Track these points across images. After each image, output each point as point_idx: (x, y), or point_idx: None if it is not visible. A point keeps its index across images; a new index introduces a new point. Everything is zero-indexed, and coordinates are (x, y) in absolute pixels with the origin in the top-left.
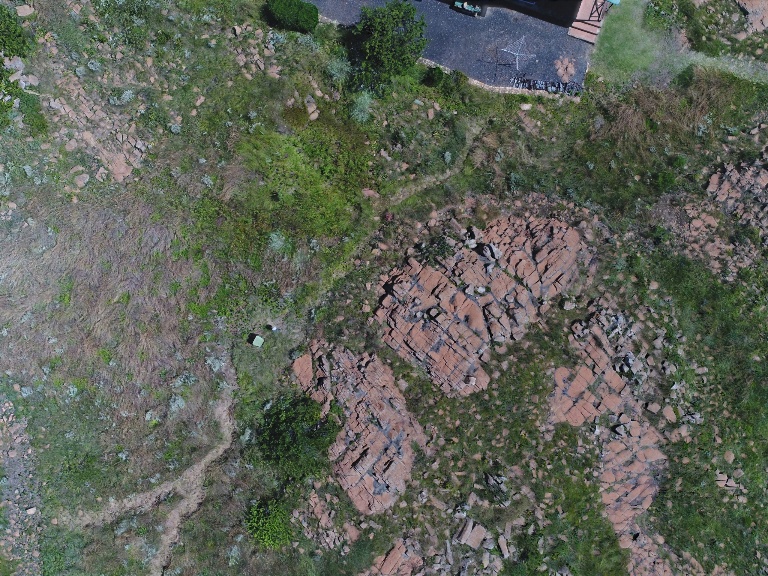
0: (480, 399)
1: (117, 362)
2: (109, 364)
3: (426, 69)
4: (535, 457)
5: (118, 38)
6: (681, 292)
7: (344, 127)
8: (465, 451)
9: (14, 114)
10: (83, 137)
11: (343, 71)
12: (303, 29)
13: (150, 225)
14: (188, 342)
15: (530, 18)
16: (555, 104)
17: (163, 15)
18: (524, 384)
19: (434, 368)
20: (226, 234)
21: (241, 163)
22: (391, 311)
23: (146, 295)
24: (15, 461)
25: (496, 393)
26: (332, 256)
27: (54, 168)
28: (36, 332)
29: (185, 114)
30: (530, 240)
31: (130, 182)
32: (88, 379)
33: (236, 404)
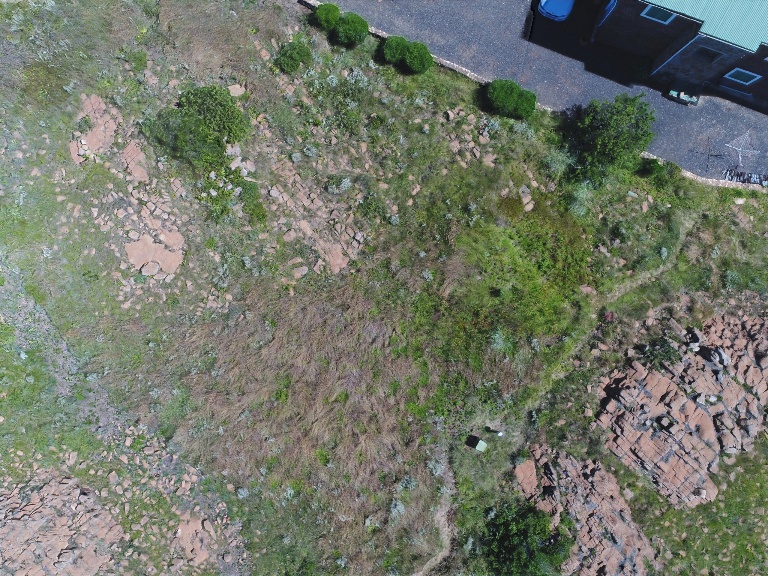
0: (708, 511)
1: (335, 464)
2: (326, 465)
3: (640, 160)
4: (761, 572)
5: (331, 121)
6: None
7: (561, 220)
8: (693, 566)
9: (234, 203)
10: (300, 226)
11: (564, 163)
12: (519, 116)
13: (369, 320)
14: (410, 446)
15: (743, 108)
16: (767, 198)
17: (375, 98)
18: (750, 496)
19: (662, 478)
20: (443, 330)
21: (461, 257)
22: (616, 417)
23: (364, 394)
24: (230, 566)
25: (722, 505)
26: (552, 356)
27: (272, 259)
28: (253, 431)
29: (402, 204)
30: (751, 343)
31: (346, 274)
32: (305, 481)
33: (456, 510)
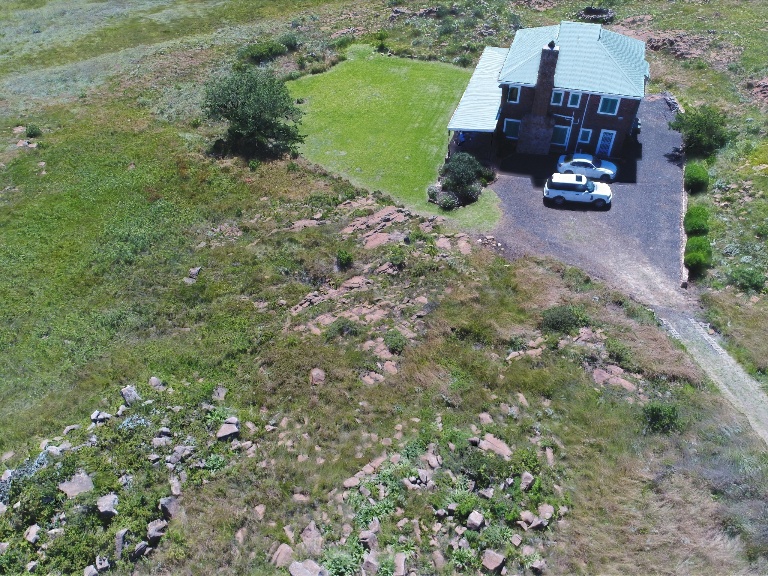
0: None
1: None
2: None
3: None
4: None
5: None
6: (762, 58)
7: (765, 152)
8: None
9: None
10: None
11: None
12: None
13: None
14: None
15: None
16: None
17: None
18: None
19: None
20: None
21: None
22: None
23: None
24: None
25: None
26: None
27: None
28: None
29: None
30: None
31: None
32: None
33: None
